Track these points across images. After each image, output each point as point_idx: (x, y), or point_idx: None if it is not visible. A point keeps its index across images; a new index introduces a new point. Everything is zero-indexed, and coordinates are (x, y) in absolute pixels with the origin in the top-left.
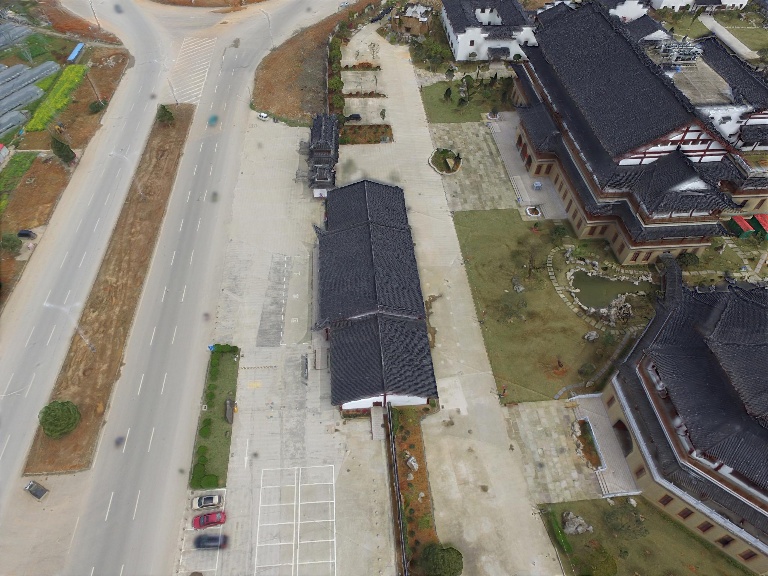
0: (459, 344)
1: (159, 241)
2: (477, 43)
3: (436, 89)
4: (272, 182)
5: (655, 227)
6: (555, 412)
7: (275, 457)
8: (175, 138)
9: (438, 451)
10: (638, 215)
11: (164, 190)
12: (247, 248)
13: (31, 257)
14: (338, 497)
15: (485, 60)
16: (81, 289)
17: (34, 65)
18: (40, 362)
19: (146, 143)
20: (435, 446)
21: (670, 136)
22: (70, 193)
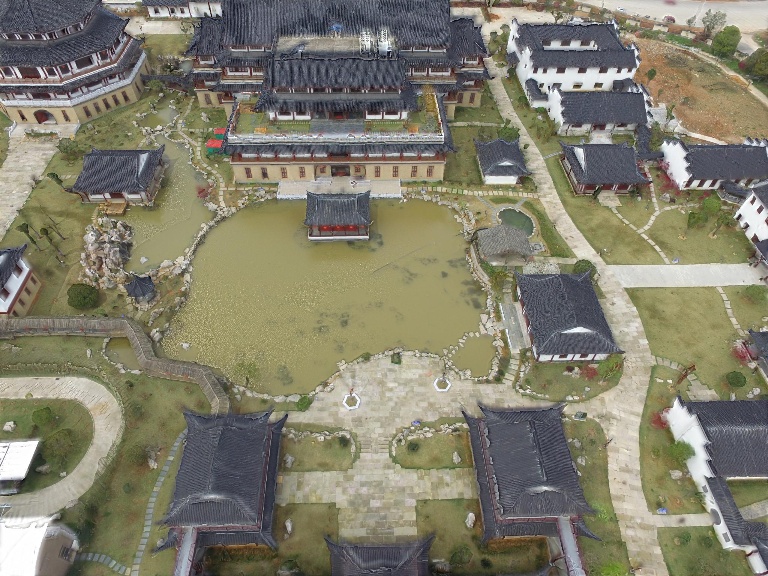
0: None
1: None
2: None
3: None
4: None
5: None
6: None
7: None
8: None
9: None
10: None
11: None
12: None
13: None
14: (122, 1)
15: None
16: None
17: None
18: None
19: None
20: None
21: None
22: None
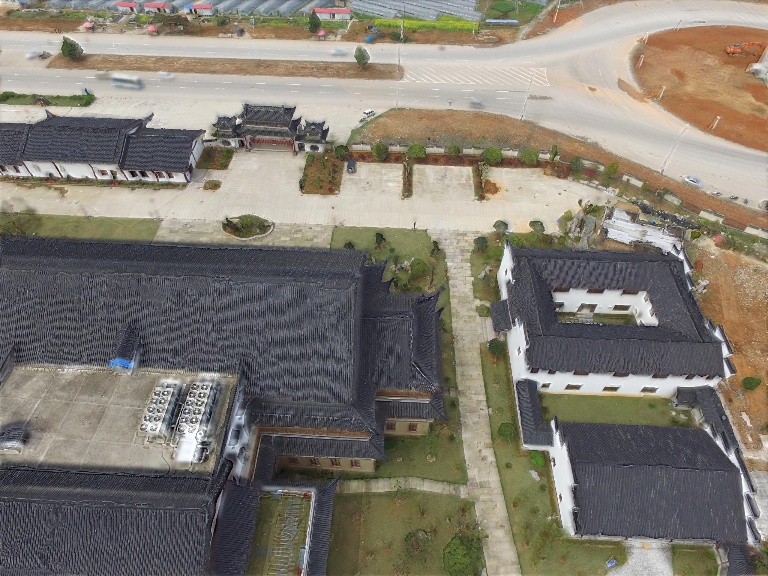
0: (8, 198)
1: (212, 75)
2: None
3: (418, 243)
4: None
5: None
6: None
7: None
8: (344, 73)
9: None
10: None
11: (270, 73)
12: (183, 108)
13: (222, 38)
14: None
15: None
16: None
17: (481, 11)
18: None
19: (338, 61)
20: None
21: None
22: (284, 41)
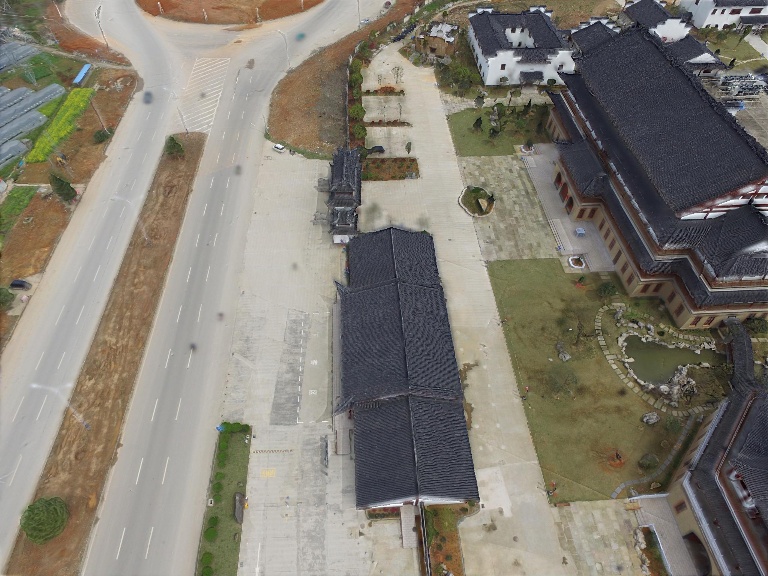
0: (499, 425)
1: (164, 293)
2: (509, 67)
3: (464, 117)
4: (288, 224)
5: (722, 291)
6: (614, 515)
7: (291, 568)
8: (184, 172)
9: (479, 564)
10: (702, 277)
11: (171, 233)
12: (260, 303)
13: (24, 311)
14: None
15: (516, 85)
16: (77, 351)
17: (38, 88)
18: (28, 441)
19: (153, 178)
20: (476, 557)
21: (744, 191)
22: (70, 235)
